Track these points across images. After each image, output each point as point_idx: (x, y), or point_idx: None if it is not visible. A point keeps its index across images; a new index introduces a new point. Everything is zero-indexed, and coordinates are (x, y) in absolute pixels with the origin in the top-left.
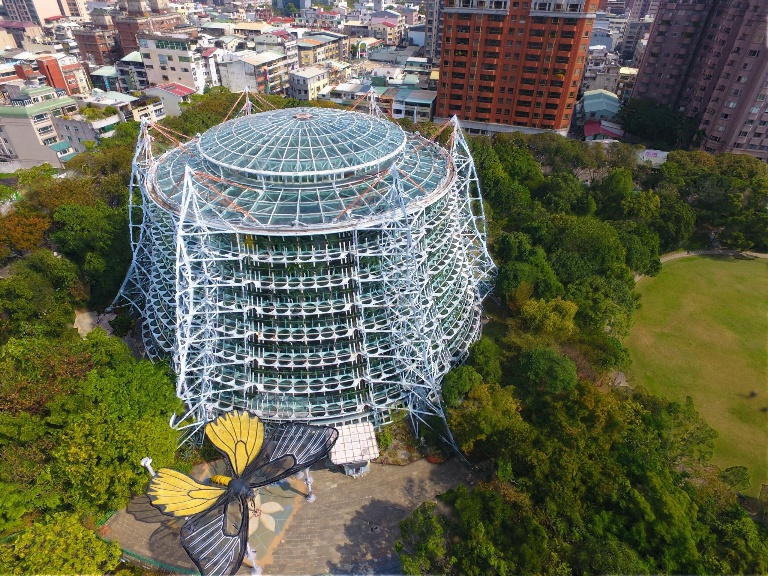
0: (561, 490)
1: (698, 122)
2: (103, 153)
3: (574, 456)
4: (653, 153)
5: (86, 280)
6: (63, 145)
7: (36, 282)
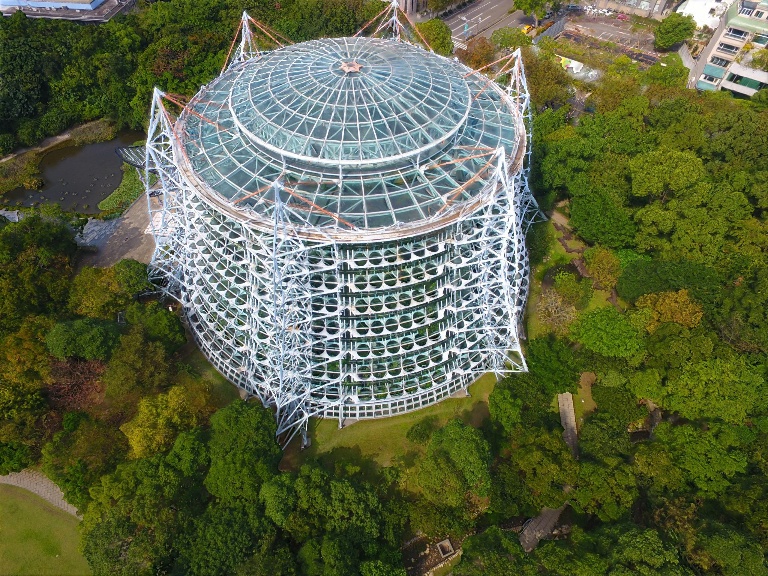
0: (4, 276)
1: None
2: (621, 76)
3: (5, 291)
4: None
5: None
6: (719, 72)
7: None
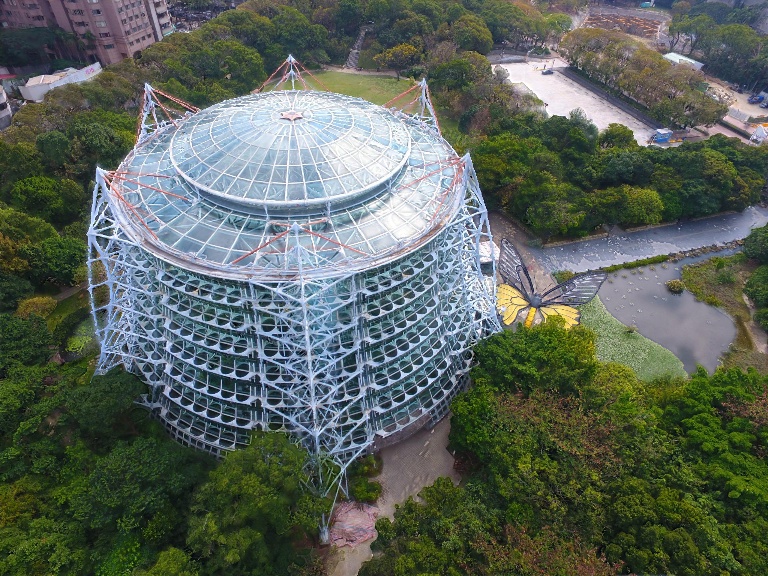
0: None
1: (61, 28)
2: None
3: (493, 159)
4: (90, 69)
5: (296, 567)
6: None
7: (372, 575)
